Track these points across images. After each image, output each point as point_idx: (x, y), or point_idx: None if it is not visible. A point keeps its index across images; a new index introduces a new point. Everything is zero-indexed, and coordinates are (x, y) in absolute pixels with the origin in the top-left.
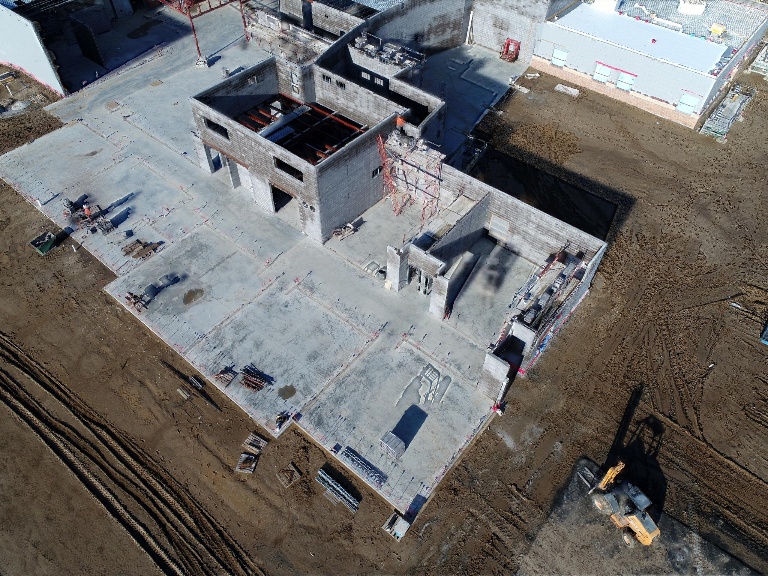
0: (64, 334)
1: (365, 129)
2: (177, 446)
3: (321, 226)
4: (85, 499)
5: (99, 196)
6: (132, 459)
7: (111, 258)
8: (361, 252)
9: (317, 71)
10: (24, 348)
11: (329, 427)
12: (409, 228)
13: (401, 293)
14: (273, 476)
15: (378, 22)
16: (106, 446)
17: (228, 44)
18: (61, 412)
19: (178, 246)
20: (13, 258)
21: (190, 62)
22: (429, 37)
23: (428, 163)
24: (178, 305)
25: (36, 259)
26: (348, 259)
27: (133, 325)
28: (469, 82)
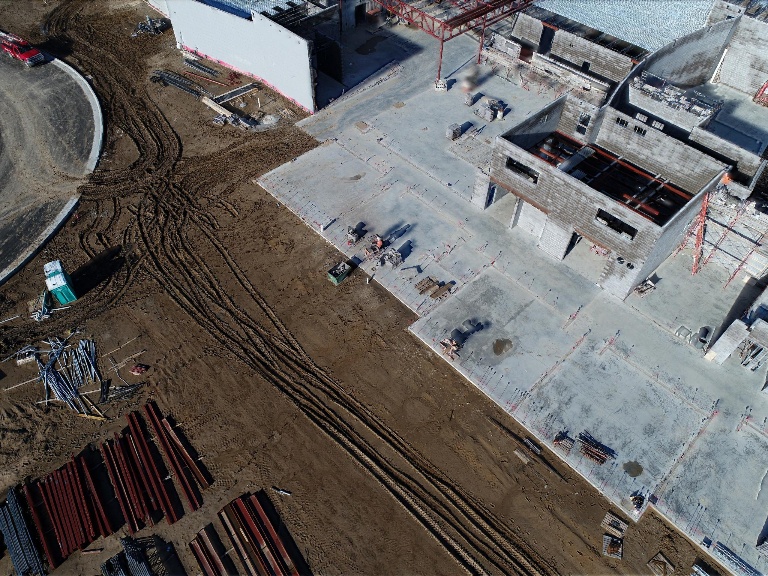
0: (380, 375)
1: (658, 178)
2: (531, 516)
3: (632, 284)
4: (451, 565)
5: (376, 225)
6: (488, 526)
7: (407, 295)
8: (666, 314)
9: (611, 113)
10: (344, 386)
11: (691, 516)
12: (711, 291)
13: (725, 366)
14: (644, 565)
15: (652, 60)
16: (457, 507)
17: (460, 66)
18: (400, 462)
19: (471, 288)
20: (307, 285)
21: (427, 84)
22: (681, 75)
23: (765, 229)
24: (490, 355)
25: (330, 288)
26: (655, 320)
27: (448, 372)
28: (726, 126)
